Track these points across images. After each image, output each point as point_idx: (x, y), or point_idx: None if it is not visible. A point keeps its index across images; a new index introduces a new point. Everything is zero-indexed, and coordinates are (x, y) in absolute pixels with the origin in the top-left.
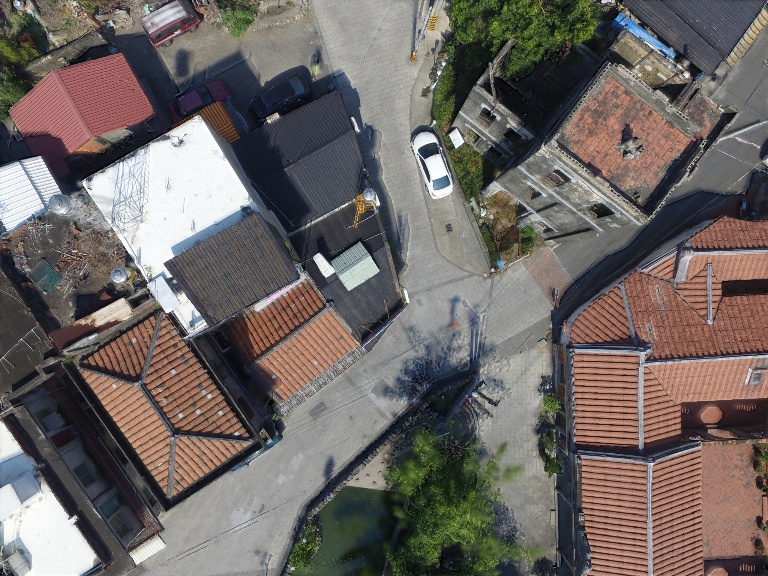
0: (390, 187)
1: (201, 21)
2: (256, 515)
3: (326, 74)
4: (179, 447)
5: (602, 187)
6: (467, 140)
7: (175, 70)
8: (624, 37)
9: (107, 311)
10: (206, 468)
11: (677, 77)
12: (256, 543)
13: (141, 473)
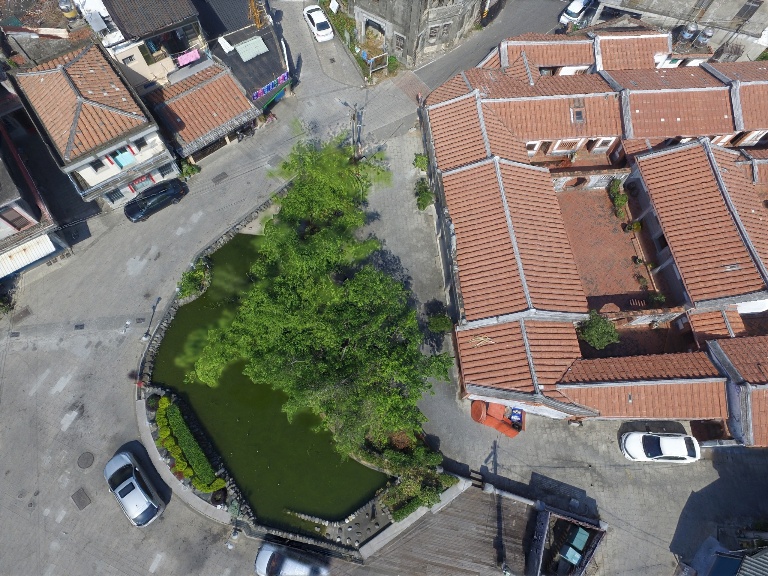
0: (288, 39)
1: None
2: (151, 262)
3: None
4: (83, 114)
5: None
6: (343, 10)
7: None
8: None
9: (50, 30)
10: (103, 137)
11: None
12: (147, 288)
13: (46, 142)
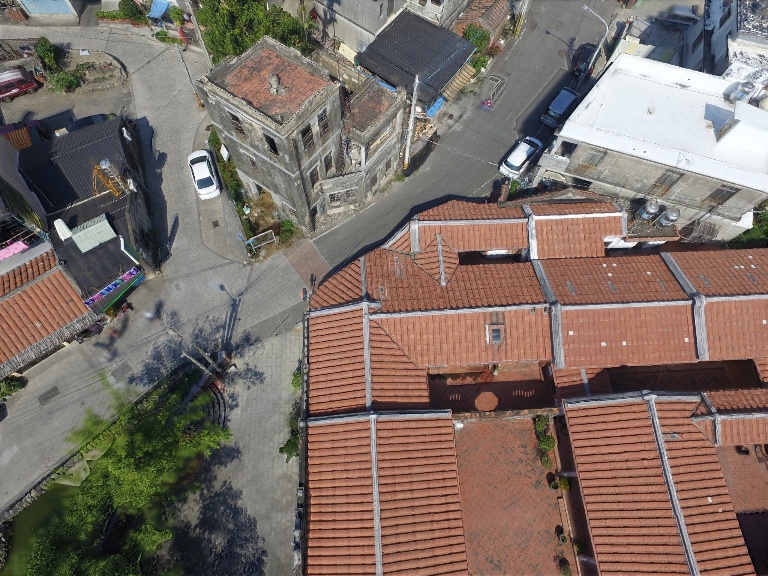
0: (167, 193)
1: (41, 87)
2: None
3: (131, 118)
4: None
5: (246, 109)
6: None
7: (9, 117)
8: (320, 55)
9: None
10: None
11: (360, 76)
12: None
13: None
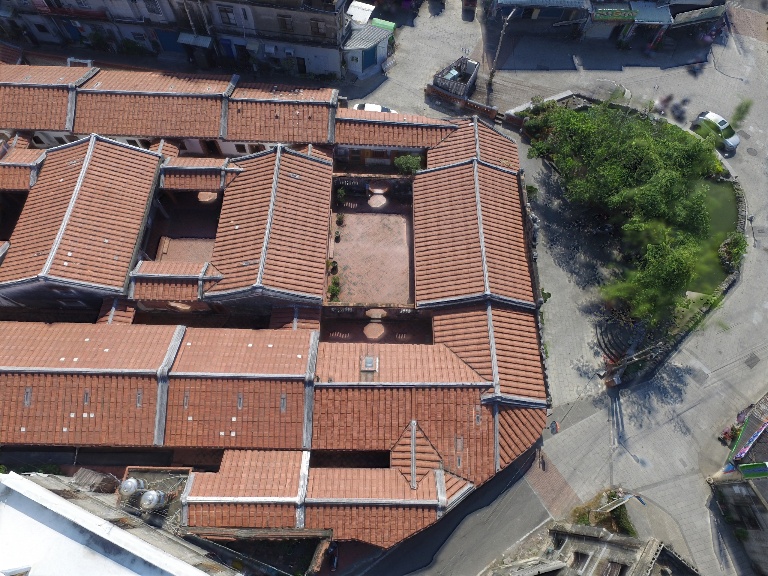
0: None
1: None
2: None
3: None
4: None
5: None
6: None
7: None
8: None
9: None
10: None
11: None
12: None
13: None
